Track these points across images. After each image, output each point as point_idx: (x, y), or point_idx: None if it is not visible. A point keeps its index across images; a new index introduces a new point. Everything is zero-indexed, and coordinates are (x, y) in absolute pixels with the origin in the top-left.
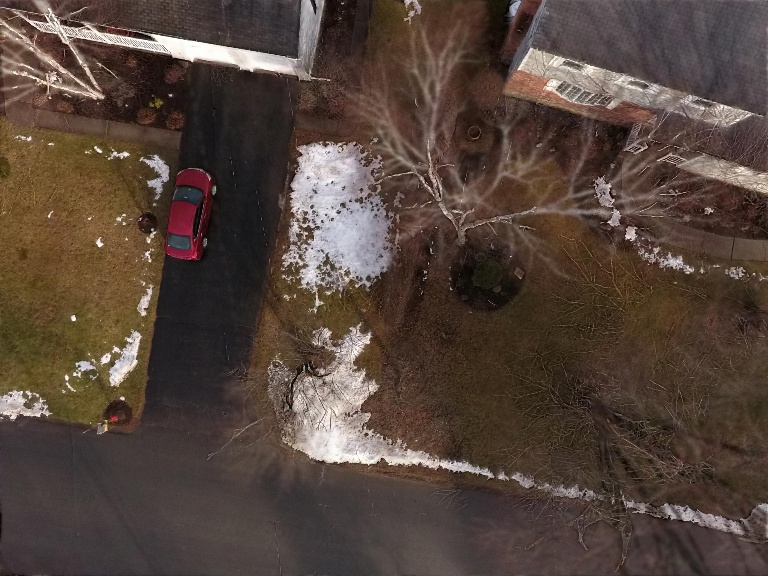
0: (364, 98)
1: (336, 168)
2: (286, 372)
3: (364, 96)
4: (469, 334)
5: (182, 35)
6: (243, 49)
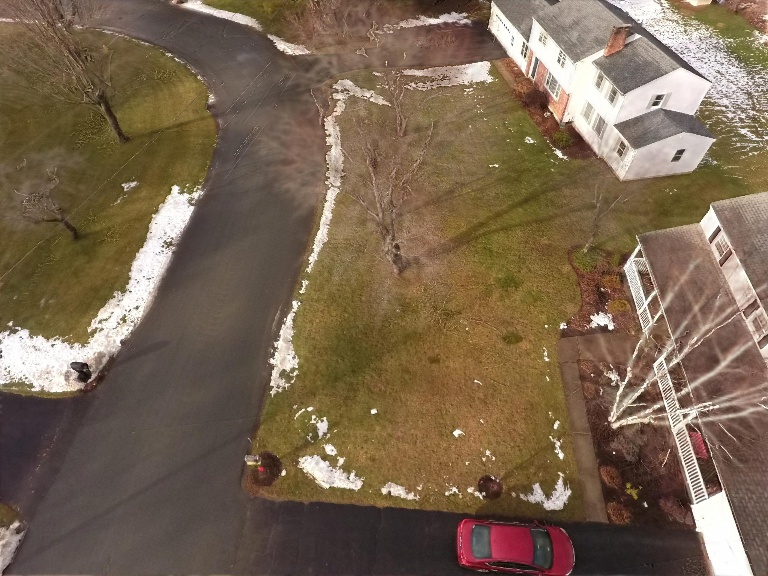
0: None
1: None
2: None
3: None
4: None
5: (748, 544)
6: None
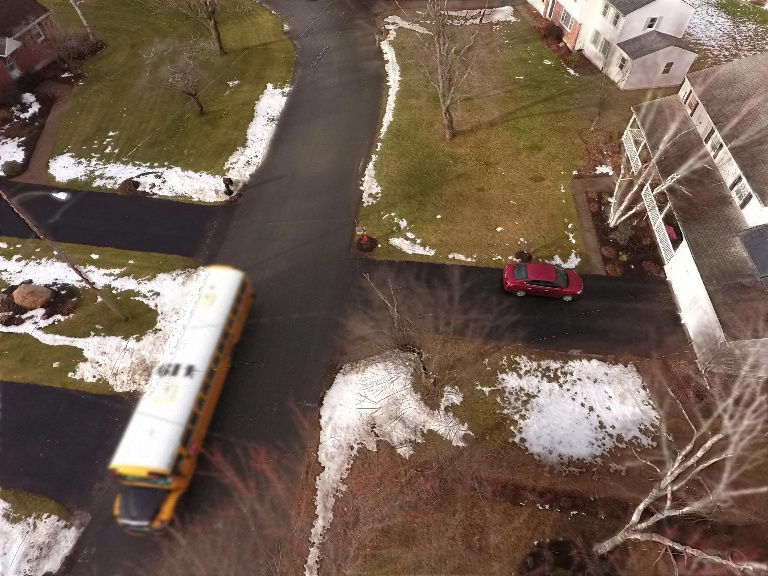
0: (708, 423)
1: (626, 399)
2: None
3: (710, 423)
4: (485, 574)
5: (697, 258)
6: (710, 300)
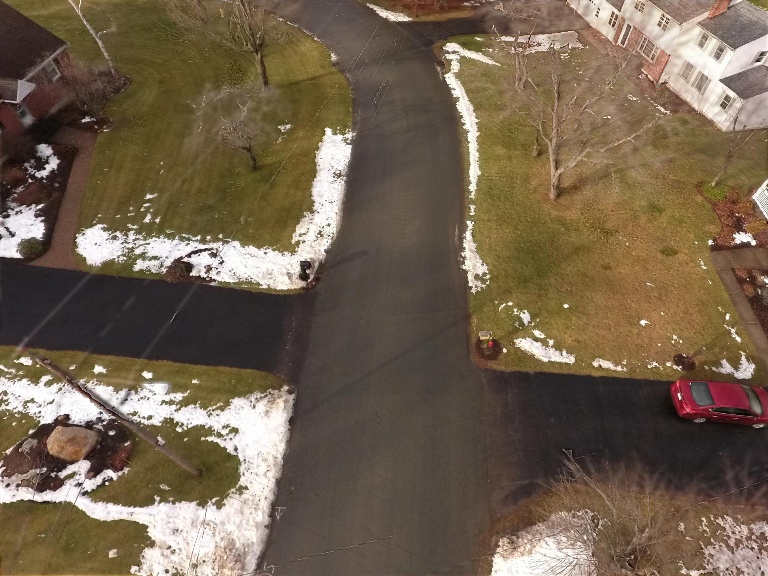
0: None
1: None
2: (592, 535)
3: None
4: None
5: None
6: None
